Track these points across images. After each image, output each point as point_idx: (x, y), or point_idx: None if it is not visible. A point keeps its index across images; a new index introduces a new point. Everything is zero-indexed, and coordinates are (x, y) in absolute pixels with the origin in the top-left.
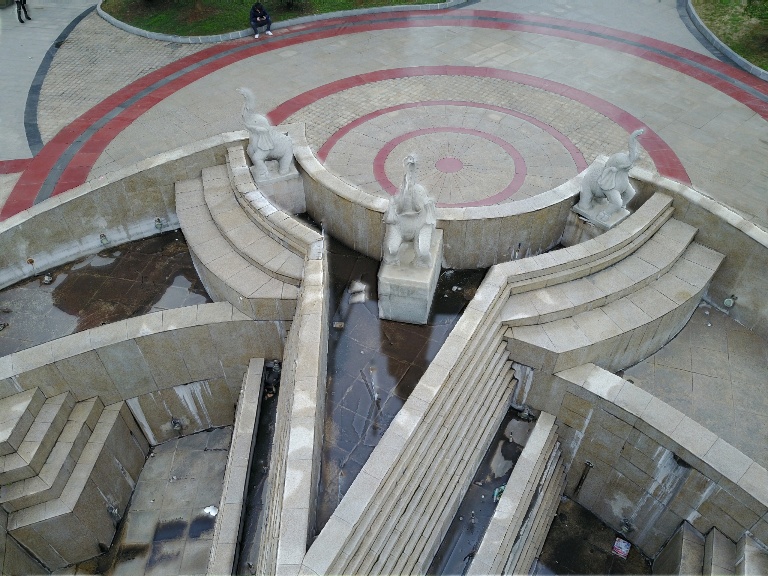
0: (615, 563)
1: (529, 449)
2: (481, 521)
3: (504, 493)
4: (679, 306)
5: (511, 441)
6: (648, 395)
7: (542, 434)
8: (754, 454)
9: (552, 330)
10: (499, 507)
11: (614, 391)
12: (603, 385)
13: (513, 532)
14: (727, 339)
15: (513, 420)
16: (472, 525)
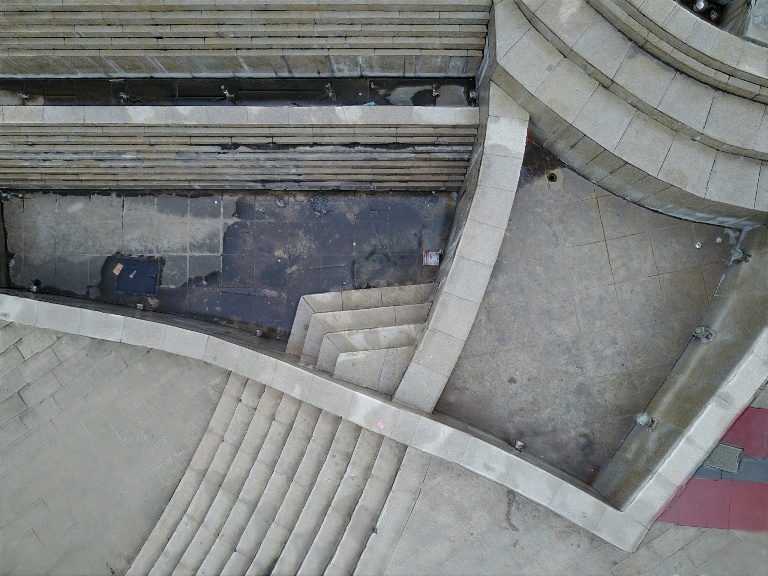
0: (415, 257)
1: (425, 111)
2: (336, 103)
3: (364, 107)
4: (657, 178)
5: (434, 95)
6: (514, 186)
7: (450, 117)
8: (520, 318)
9: (530, 42)
10: (347, 108)
11: (500, 150)
12: (503, 136)
13: (346, 137)
14: (683, 270)
15: (462, 88)
16: (327, 96)
